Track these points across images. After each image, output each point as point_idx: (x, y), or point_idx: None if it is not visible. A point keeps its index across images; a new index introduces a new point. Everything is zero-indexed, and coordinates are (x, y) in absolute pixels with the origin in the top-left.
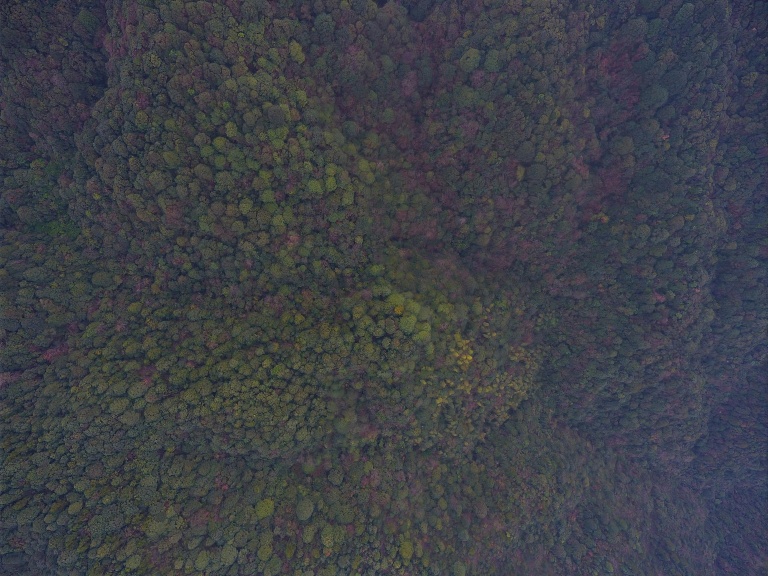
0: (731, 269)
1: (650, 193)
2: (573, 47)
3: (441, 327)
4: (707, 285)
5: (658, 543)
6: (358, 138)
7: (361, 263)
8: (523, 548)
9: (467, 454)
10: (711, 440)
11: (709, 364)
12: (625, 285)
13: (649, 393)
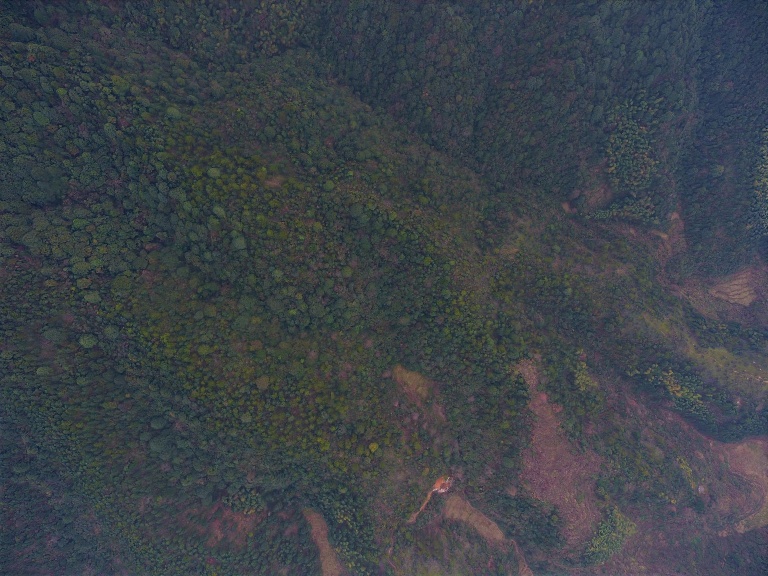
0: None
1: None
2: None
3: None
4: None
5: (416, 183)
6: None
7: None
8: (261, 138)
9: (223, 62)
10: (489, 113)
11: (474, 13)
12: None
13: (411, 30)
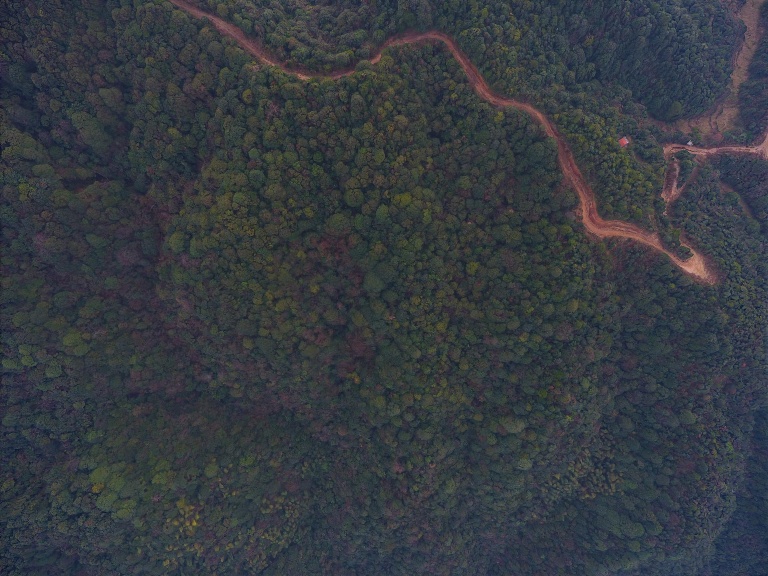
0: (477, 440)
1: (388, 365)
2: (273, 239)
3: (153, 499)
4: (455, 453)
5: None
6: (77, 306)
7: (83, 427)
8: None
9: None
10: None
11: (475, 521)
12: (376, 446)
13: (408, 550)
